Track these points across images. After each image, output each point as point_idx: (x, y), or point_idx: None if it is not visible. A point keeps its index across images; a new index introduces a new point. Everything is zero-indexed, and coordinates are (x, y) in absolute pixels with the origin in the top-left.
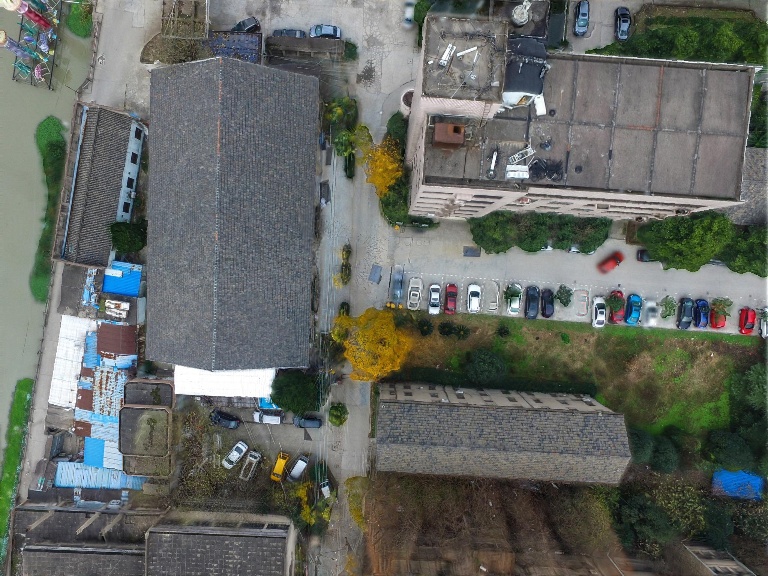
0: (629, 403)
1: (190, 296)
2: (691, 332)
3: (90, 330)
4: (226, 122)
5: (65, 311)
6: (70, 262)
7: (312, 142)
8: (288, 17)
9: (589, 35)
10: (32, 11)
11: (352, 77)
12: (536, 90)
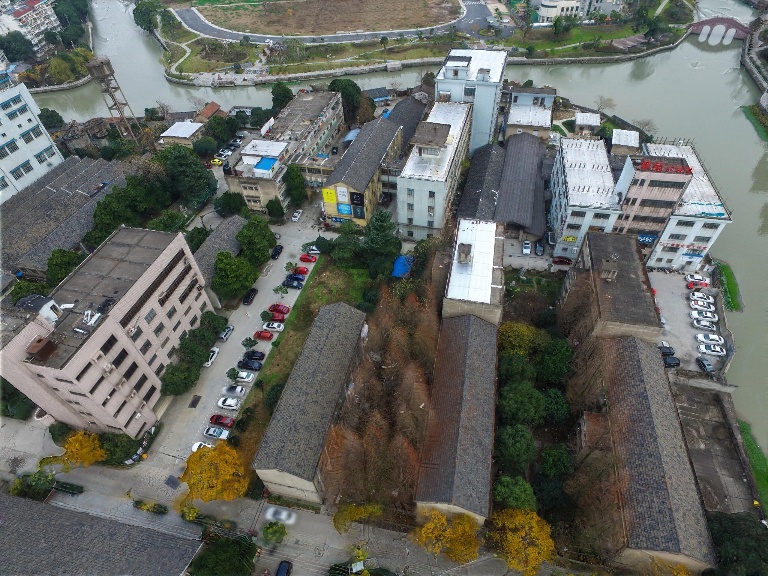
0: None
1: None
2: (306, 283)
3: None
4: None
5: None
6: None
7: (16, 501)
8: None
9: None
10: None
11: (8, 477)
12: (49, 300)
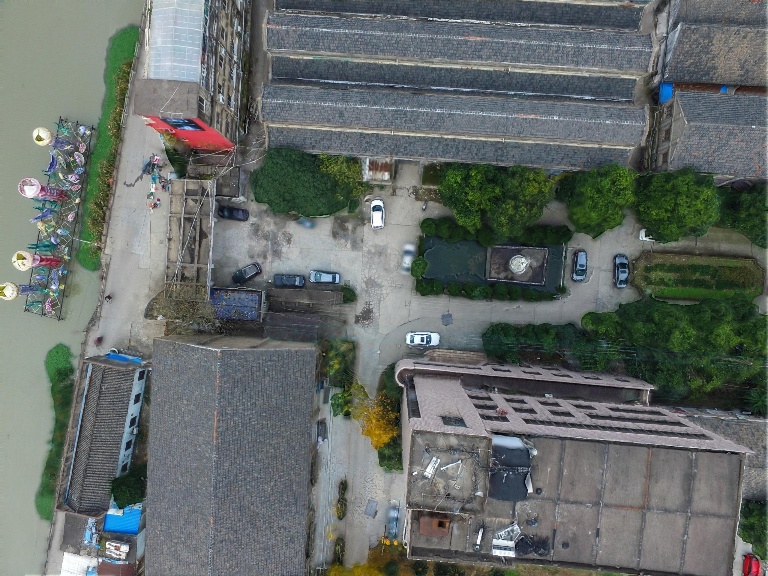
0: None
1: (186, 569)
2: None
3: (91, 565)
4: (223, 411)
5: (67, 549)
6: (73, 512)
7: (308, 411)
8: (288, 260)
9: (587, 280)
10: (44, 259)
11: (350, 317)
12: (520, 498)
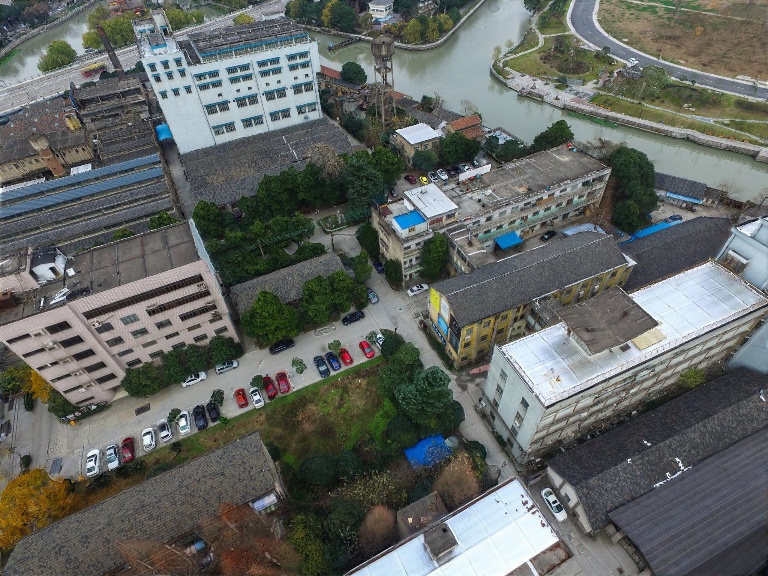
0: (315, 447)
1: None
2: (335, 376)
3: None
4: None
5: None
6: None
7: None
8: None
9: None
10: None
11: None
12: (50, 261)
